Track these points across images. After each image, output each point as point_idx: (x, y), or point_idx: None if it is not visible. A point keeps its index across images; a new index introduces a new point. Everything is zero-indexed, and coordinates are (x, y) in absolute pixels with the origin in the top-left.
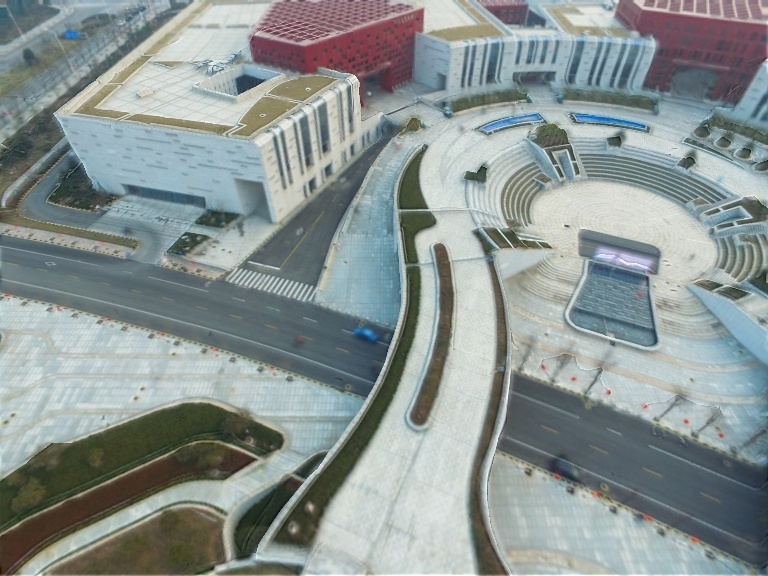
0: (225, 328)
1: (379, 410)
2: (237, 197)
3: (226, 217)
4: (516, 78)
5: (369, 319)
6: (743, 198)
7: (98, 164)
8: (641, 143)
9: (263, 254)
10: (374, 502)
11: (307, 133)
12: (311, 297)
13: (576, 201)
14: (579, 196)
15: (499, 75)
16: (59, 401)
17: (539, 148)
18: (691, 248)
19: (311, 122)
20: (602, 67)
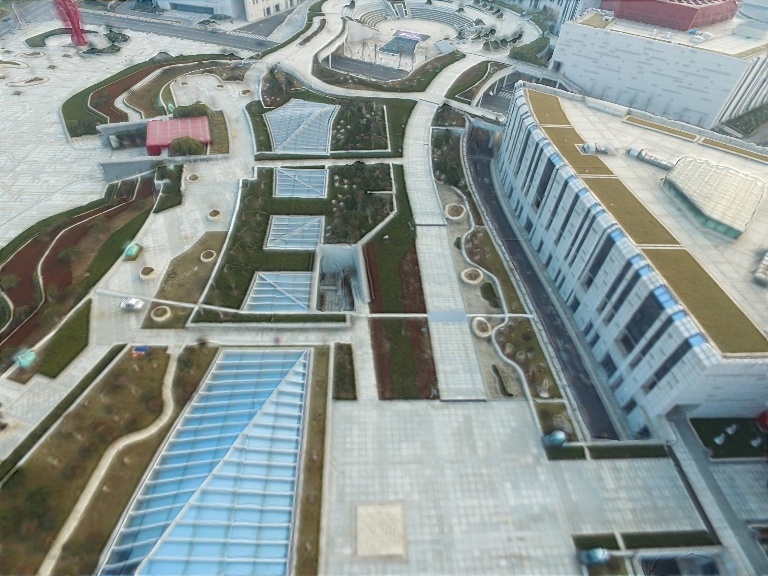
0: (227, 42)
1: (287, 43)
2: (230, 6)
3: (224, 17)
4: None
5: None
6: None
7: None
8: (444, 5)
9: (243, 29)
10: None
11: None
12: (265, 39)
13: (402, 24)
14: (404, 23)
15: None
16: (161, 51)
17: (388, 2)
18: (446, 37)
19: None
20: None
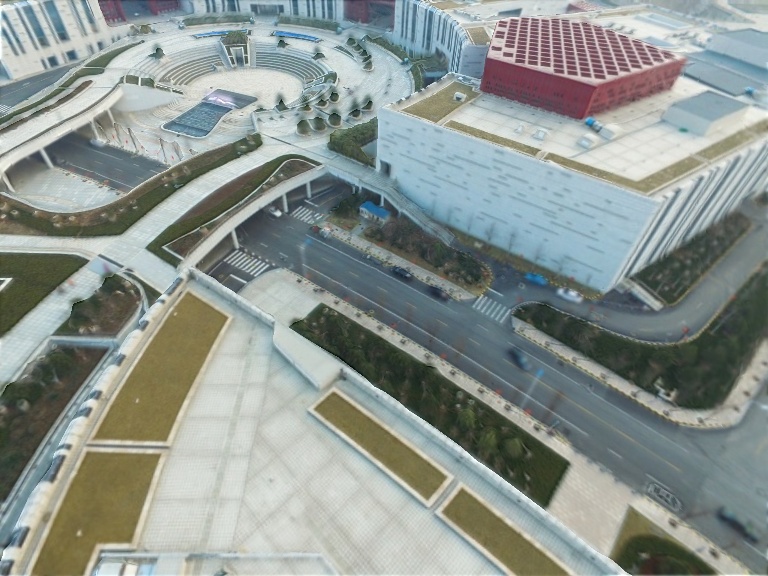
0: None
1: None
2: None
3: None
4: (255, 9)
5: None
6: None
7: None
8: (304, 47)
9: None
10: None
11: (35, 19)
12: (5, 111)
13: (234, 78)
14: (239, 75)
15: (239, 5)
16: None
17: (223, 45)
18: None
19: (37, 12)
20: (314, 2)
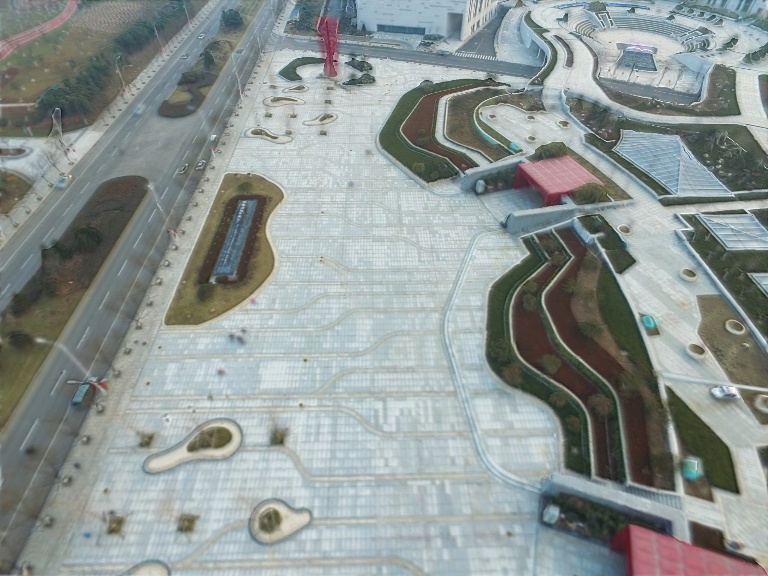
0: (464, 65)
1: (553, 65)
2: (445, 25)
3: (438, 37)
4: None
5: (527, 64)
6: (698, 27)
7: (369, 12)
8: (646, 13)
9: (464, 49)
10: (560, 80)
11: None
12: (496, 59)
13: (613, 36)
14: (614, 34)
15: None
16: (412, 78)
17: (591, 12)
18: (672, 48)
19: None
20: None
